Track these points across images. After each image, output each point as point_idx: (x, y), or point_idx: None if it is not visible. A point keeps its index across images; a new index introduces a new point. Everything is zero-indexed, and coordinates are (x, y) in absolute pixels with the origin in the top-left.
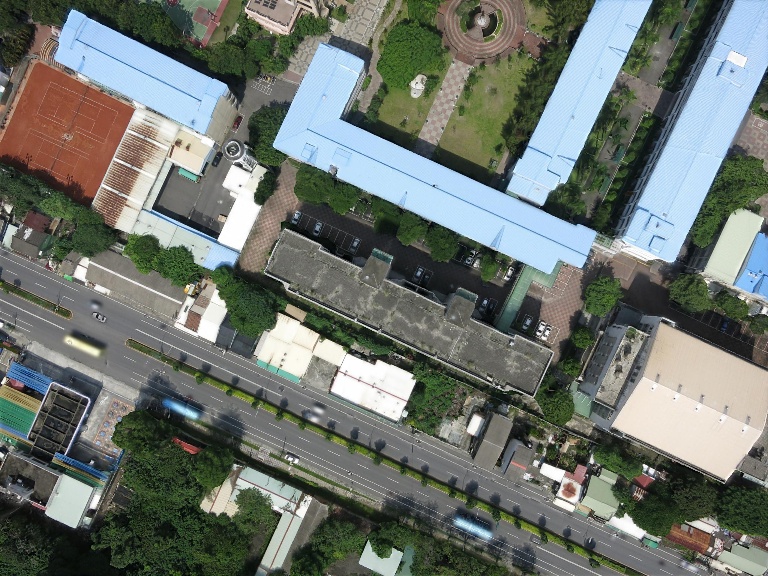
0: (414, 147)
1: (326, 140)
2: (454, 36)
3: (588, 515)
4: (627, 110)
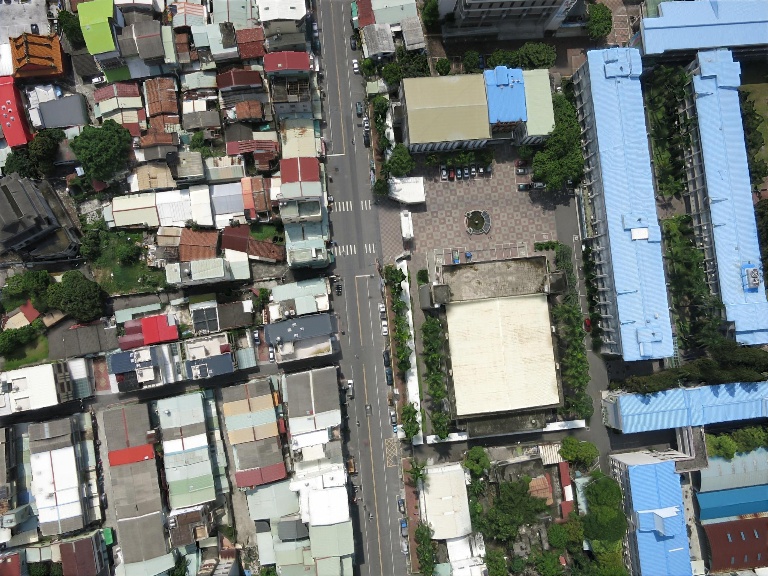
0: None
1: None
2: None
3: None
4: None
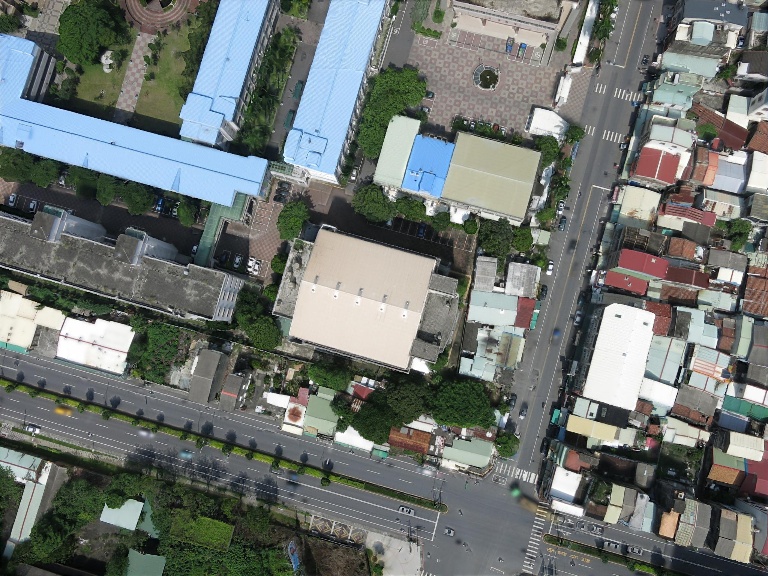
0: (112, 117)
1: (8, 119)
2: (137, 12)
3: (316, 436)
4: (302, 50)
